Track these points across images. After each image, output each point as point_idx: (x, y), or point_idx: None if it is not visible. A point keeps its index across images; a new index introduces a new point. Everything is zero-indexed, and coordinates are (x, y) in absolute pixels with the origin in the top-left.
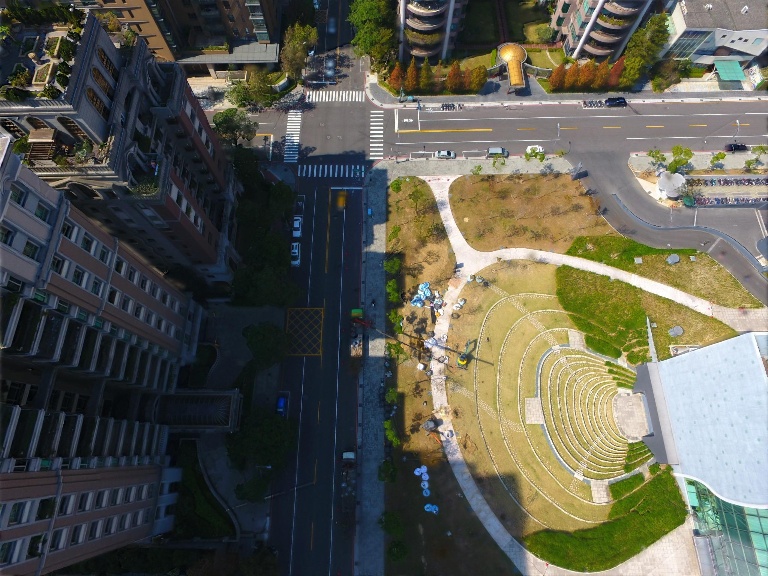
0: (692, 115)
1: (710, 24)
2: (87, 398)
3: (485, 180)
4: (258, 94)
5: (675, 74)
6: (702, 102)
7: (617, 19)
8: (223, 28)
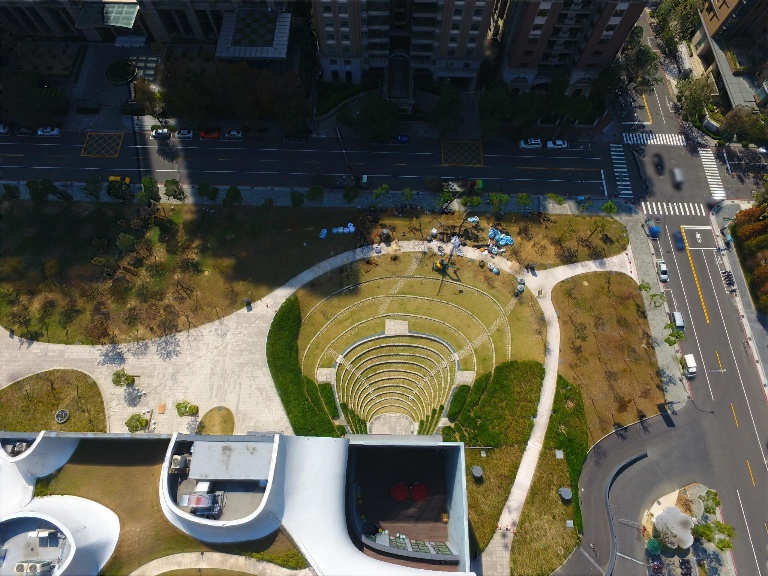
0: None
1: None
2: (405, 6)
3: (638, 308)
4: (691, 98)
5: None
6: None
7: None
8: (759, 59)
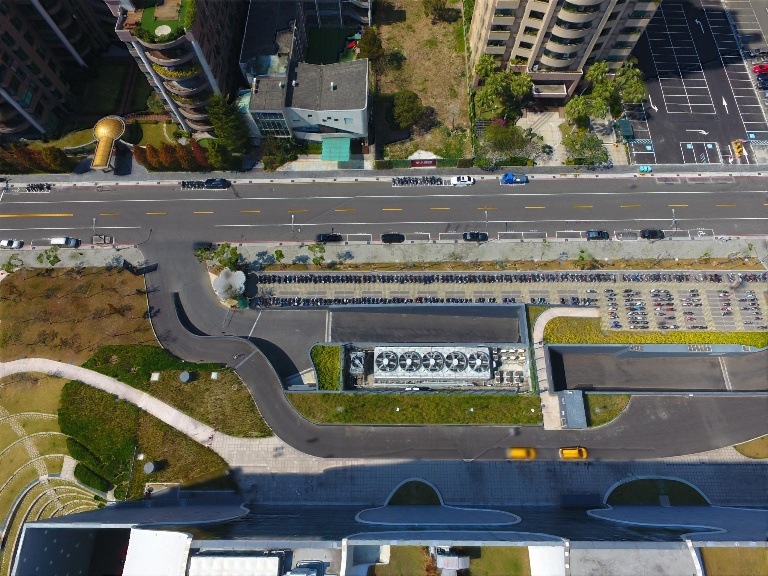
0: (296, 198)
1: (277, 105)
2: None
3: (41, 275)
4: None
5: (281, 153)
6: (313, 183)
7: (184, 98)
8: None
